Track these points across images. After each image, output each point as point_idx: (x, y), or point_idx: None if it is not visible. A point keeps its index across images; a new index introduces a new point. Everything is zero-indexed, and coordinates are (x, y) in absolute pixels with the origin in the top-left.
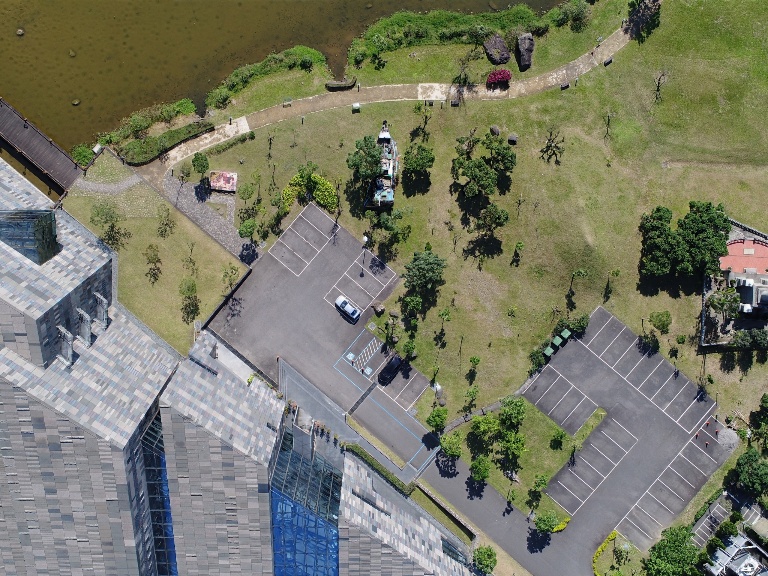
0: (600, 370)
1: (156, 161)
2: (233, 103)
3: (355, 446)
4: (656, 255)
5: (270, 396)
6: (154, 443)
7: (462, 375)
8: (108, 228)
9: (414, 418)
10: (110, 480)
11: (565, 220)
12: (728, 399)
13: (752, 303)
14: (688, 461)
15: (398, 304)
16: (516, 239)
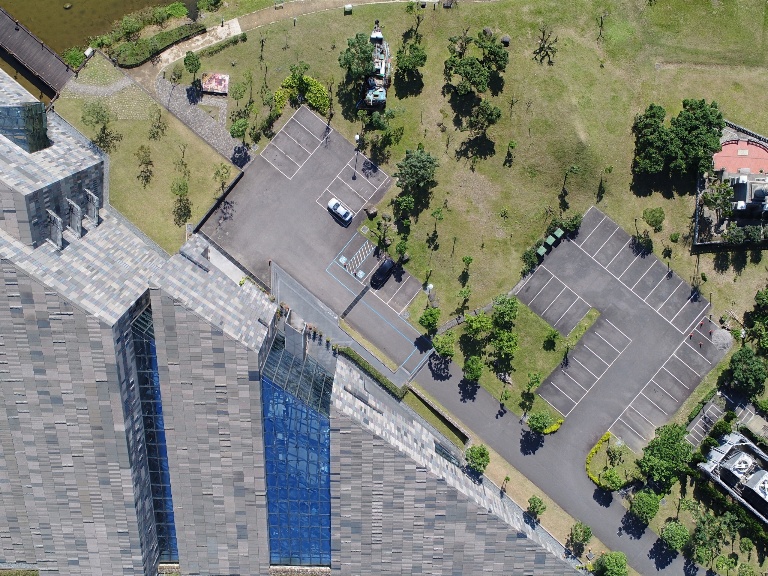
0: (593, 270)
1: (148, 63)
2: (225, 5)
3: (347, 349)
4: (649, 152)
5: (262, 298)
6: (144, 330)
7: (455, 277)
8: (100, 130)
9: (407, 321)
10: (99, 359)
11: (558, 119)
12: (722, 299)
13: (746, 199)
14: (682, 362)
15: (391, 207)
16: (509, 139)
